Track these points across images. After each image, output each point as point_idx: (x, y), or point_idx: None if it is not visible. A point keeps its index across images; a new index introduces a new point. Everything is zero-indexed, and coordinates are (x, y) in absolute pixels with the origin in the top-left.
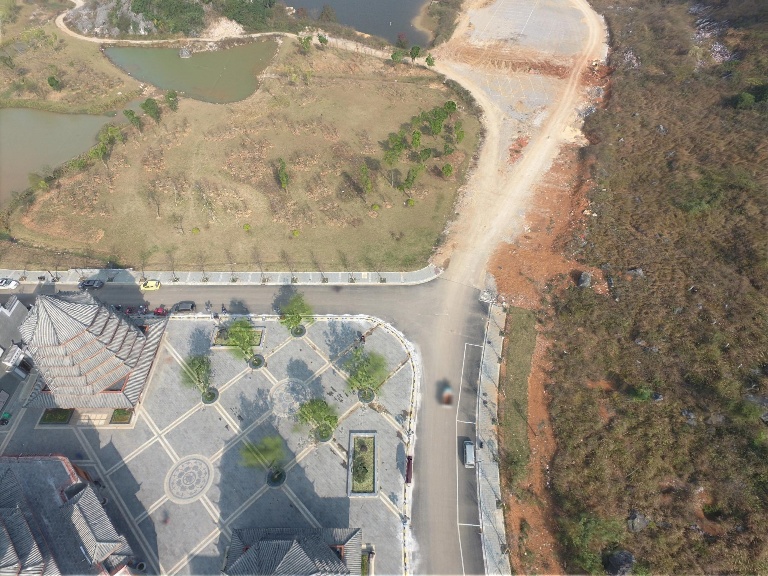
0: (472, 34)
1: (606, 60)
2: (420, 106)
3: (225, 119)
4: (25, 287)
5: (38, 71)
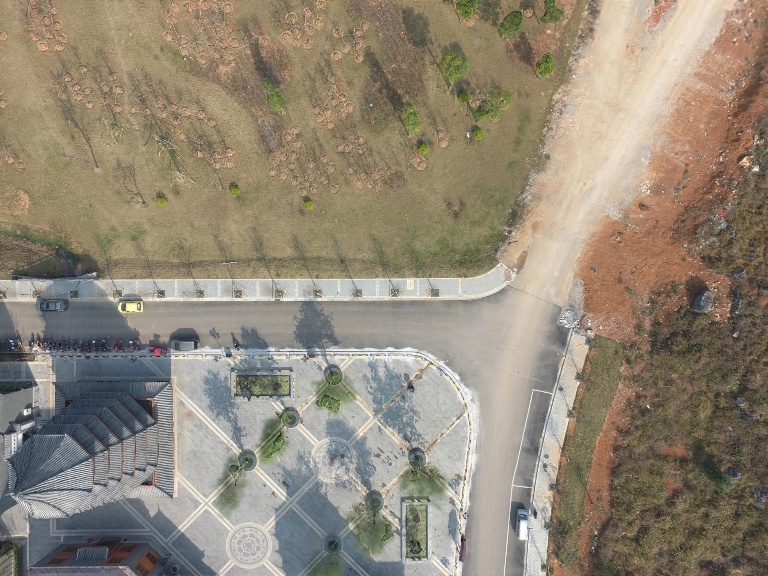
0: None
1: None
2: None
3: None
4: None
5: None
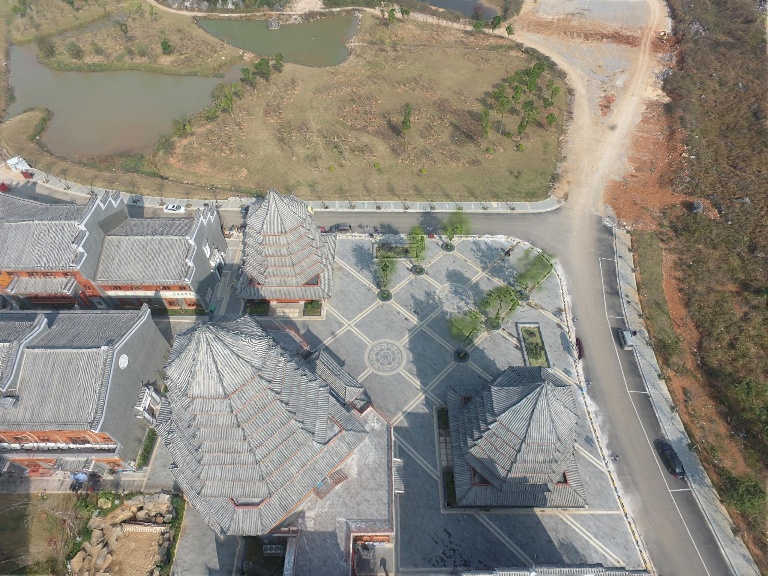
0: (539, 9)
1: (672, 31)
2: (507, 69)
3: (328, 80)
4: (193, 212)
5: (144, 38)
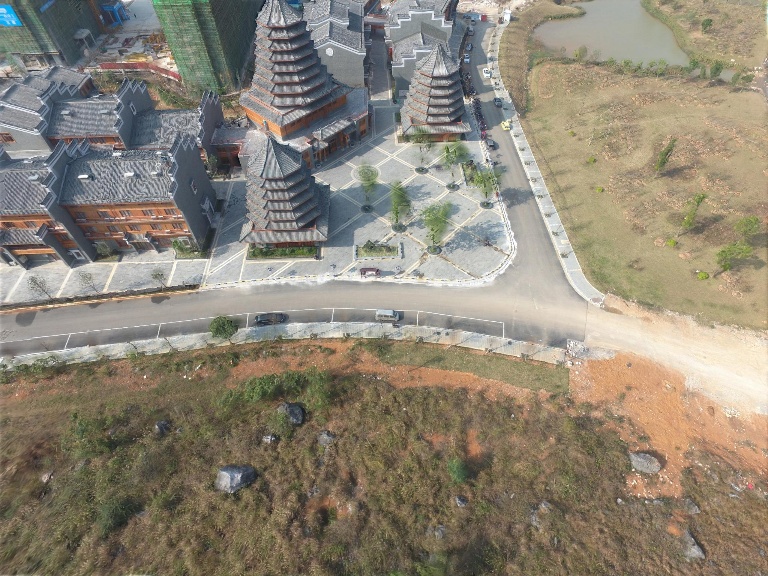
0: None
1: None
2: None
3: (749, 123)
4: (488, 81)
5: None
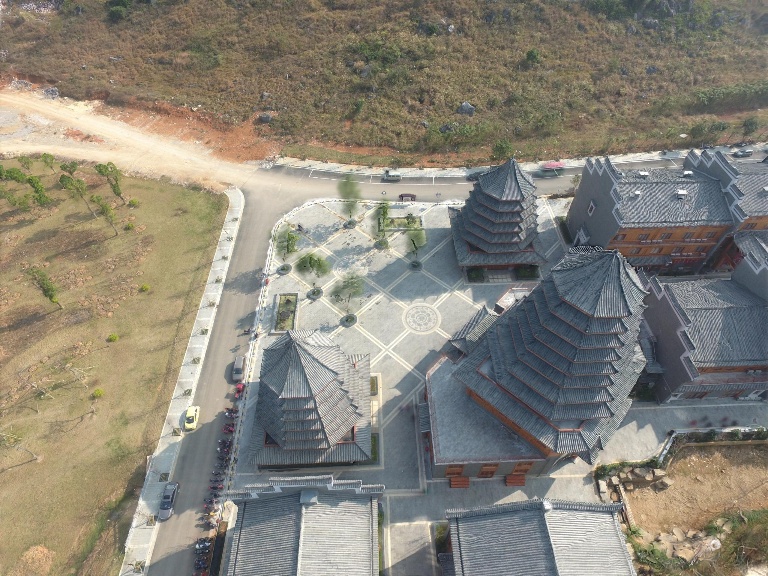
0: None
1: None
2: None
3: None
4: None
5: None
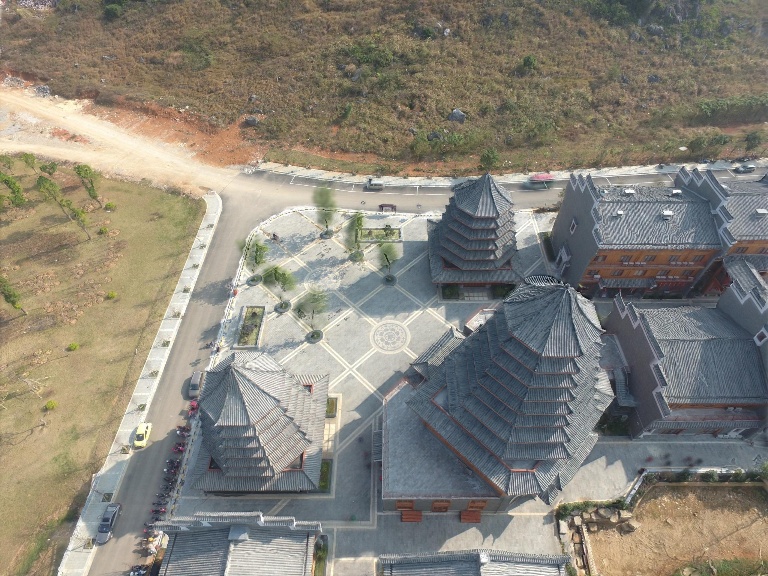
0: None
1: None
2: None
3: None
4: None
5: None
